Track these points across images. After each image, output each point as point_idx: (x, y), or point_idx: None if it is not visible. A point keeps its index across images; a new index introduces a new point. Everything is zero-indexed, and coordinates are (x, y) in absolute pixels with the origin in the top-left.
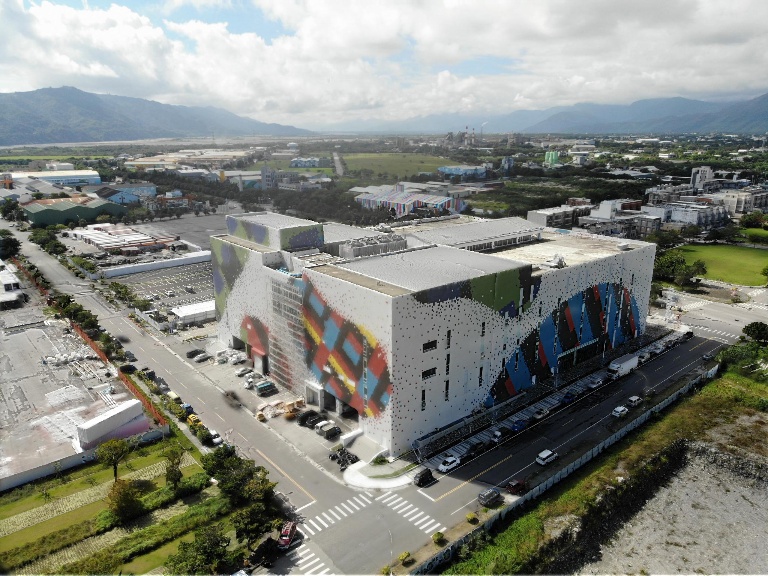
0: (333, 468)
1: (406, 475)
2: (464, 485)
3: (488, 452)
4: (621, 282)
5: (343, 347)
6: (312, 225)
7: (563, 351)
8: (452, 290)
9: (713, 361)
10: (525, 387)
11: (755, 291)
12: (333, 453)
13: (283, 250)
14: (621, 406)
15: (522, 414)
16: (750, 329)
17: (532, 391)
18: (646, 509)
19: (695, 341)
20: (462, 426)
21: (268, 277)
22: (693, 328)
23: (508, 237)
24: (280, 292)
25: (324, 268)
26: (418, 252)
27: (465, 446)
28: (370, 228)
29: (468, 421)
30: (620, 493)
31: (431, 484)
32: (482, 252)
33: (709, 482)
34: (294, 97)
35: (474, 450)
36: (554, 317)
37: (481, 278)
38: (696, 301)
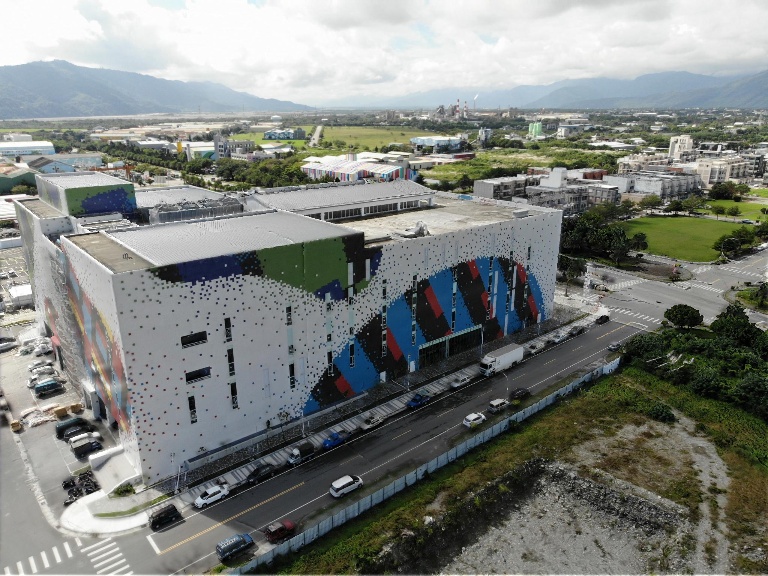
0: (58, 501)
1: (146, 512)
2: (214, 528)
3: (276, 477)
4: (511, 256)
5: (96, 339)
6: (116, 185)
7: (427, 341)
8: (225, 265)
9: (619, 352)
10: (369, 386)
11: (701, 268)
12: (69, 479)
13: (71, 215)
14: (477, 412)
15: (349, 423)
16: (672, 313)
17: (377, 392)
18: (458, 561)
19: (608, 327)
20: (262, 440)
21: (46, 249)
22: (612, 311)
23: (384, 202)
24: (56, 268)
25: (89, 237)
26: (243, 218)
27: (250, 468)
28: (239, 193)
29: (272, 433)
30: (421, 540)
31: (171, 526)
32: (345, 220)
33: (558, 519)
34: (130, 32)
35: (254, 475)
36: (408, 299)
37: (276, 249)
38: (629, 279)
